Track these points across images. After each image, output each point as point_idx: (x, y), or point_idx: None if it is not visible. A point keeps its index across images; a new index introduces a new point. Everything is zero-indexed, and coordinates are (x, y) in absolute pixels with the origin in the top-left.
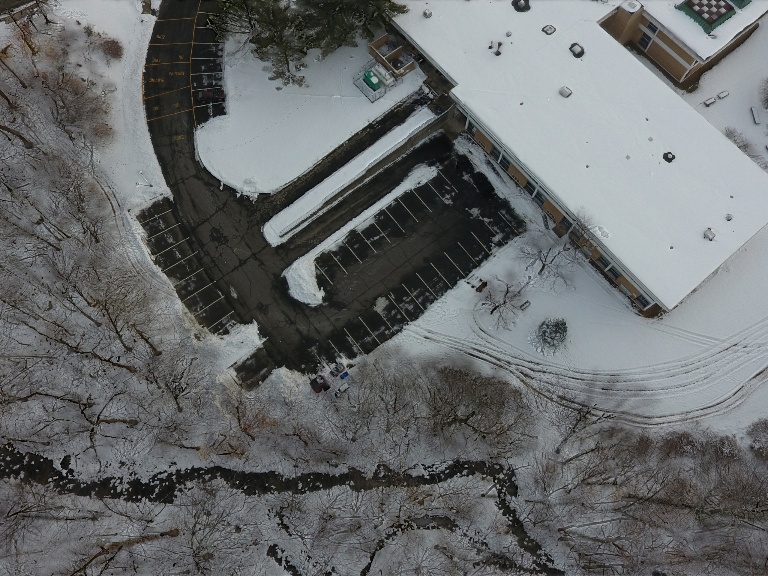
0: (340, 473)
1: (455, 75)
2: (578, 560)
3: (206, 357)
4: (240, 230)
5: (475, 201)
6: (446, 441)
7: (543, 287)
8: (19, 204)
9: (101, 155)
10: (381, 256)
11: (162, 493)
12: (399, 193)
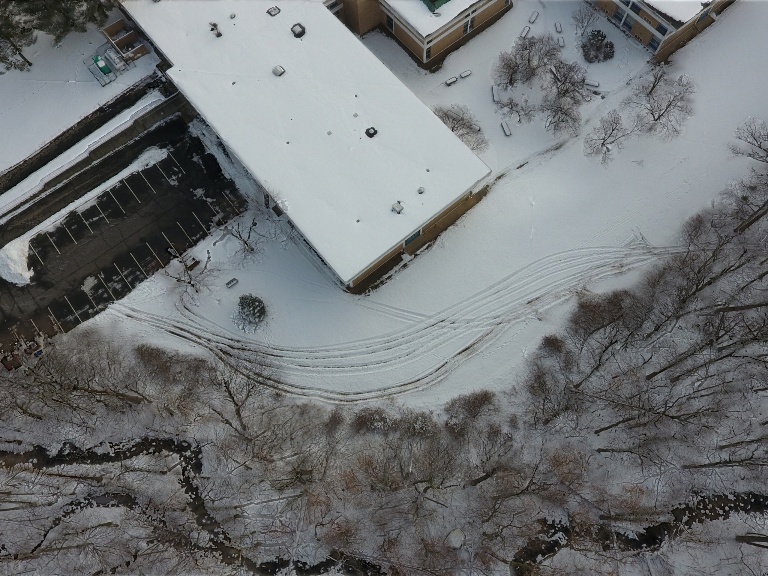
0: (25, 451)
1: (173, 57)
2: (251, 538)
3: None
4: None
5: (201, 182)
6: (134, 418)
7: (234, 263)
8: None
9: None
10: (97, 236)
11: None
12: (125, 175)
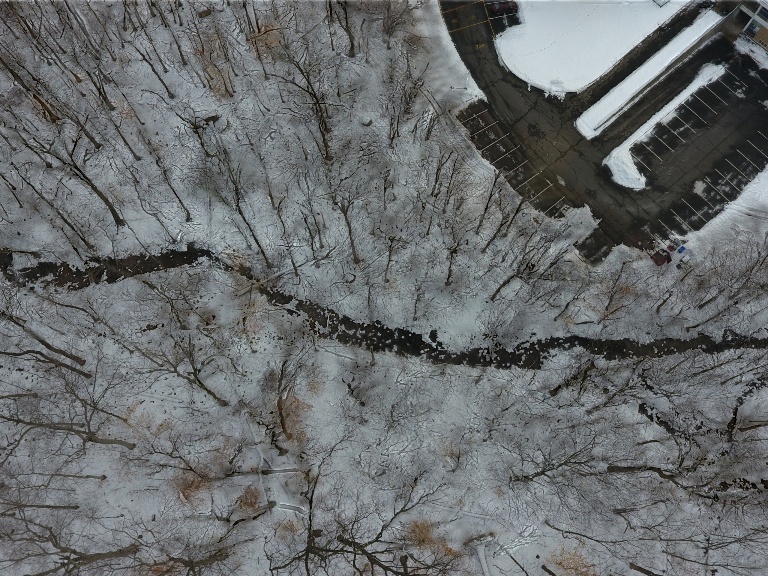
0: (690, 338)
1: None
2: None
3: None
4: (555, 126)
5: (766, 94)
6: None
7: None
8: (349, 108)
9: (416, 62)
10: (690, 145)
11: (529, 360)
12: (694, 89)
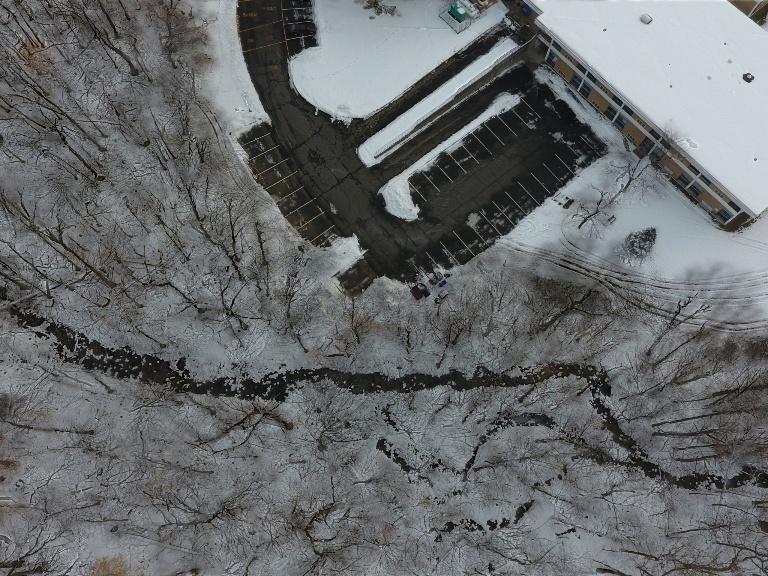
0: (442, 374)
1: (540, 4)
2: (672, 453)
3: (310, 267)
4: (336, 152)
5: (558, 126)
6: (541, 345)
7: (632, 198)
8: (127, 127)
9: (202, 82)
10: (471, 176)
11: (274, 392)
12: (485, 118)
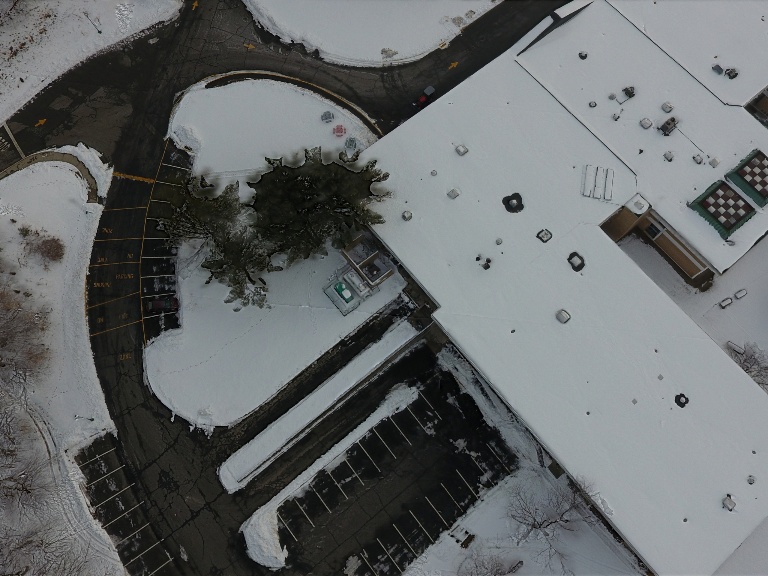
0: None
1: (437, 294)
2: None
3: None
4: (193, 473)
5: (461, 430)
6: None
7: (537, 561)
8: None
9: (35, 383)
10: (353, 503)
11: None
12: (374, 422)
